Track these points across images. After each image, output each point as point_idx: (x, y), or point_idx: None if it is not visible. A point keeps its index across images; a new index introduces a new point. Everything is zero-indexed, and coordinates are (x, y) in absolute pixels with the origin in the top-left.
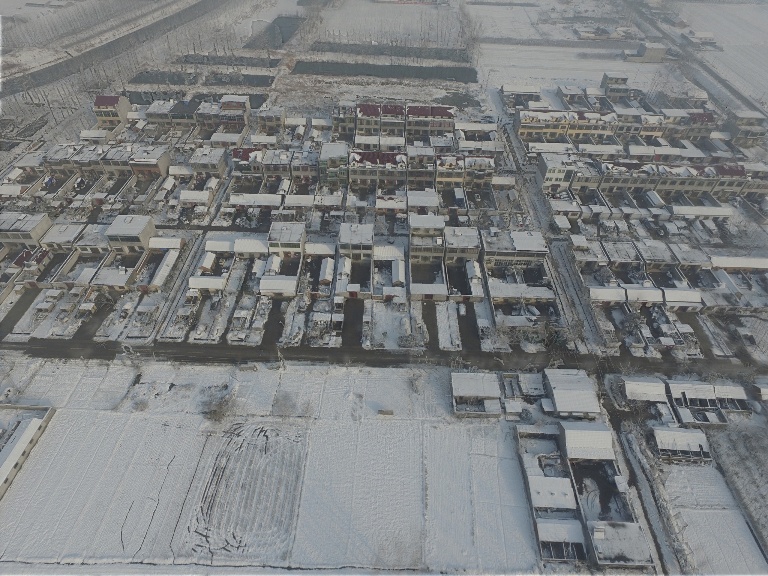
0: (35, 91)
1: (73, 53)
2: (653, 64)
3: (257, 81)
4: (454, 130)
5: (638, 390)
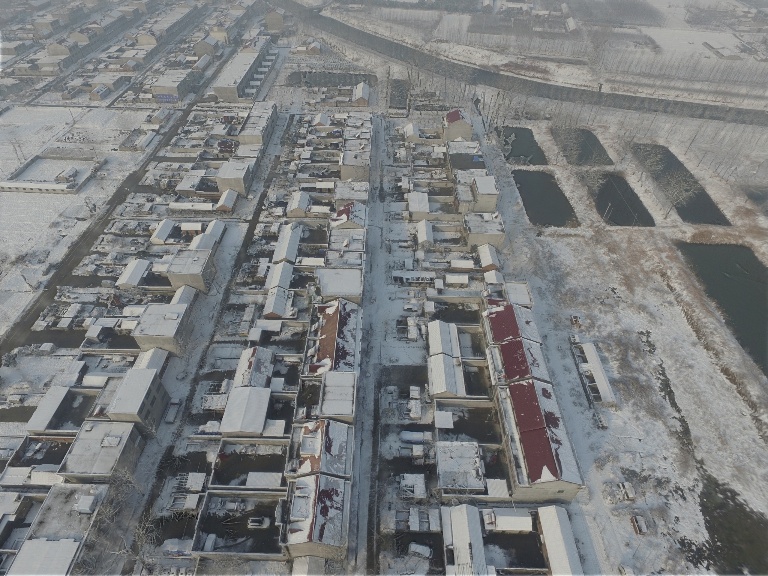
0: (470, 87)
1: (605, 88)
2: None
3: (649, 218)
4: (535, 507)
5: None
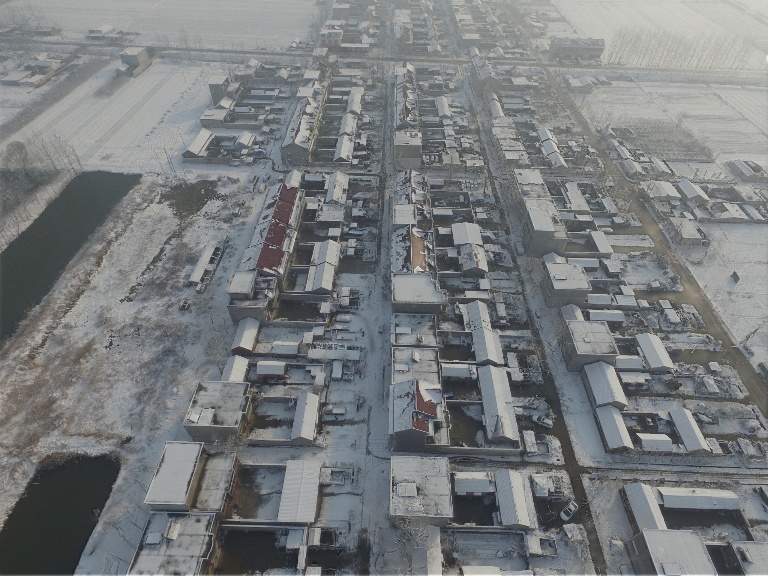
0: None
1: None
2: (152, 67)
3: None
4: None
5: (639, 169)
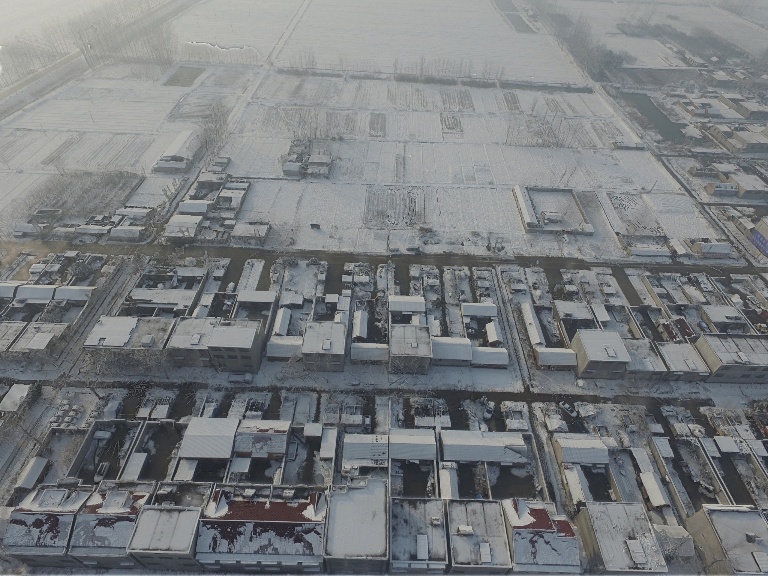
0: None
1: None
2: None
3: None
4: None
5: (134, 228)
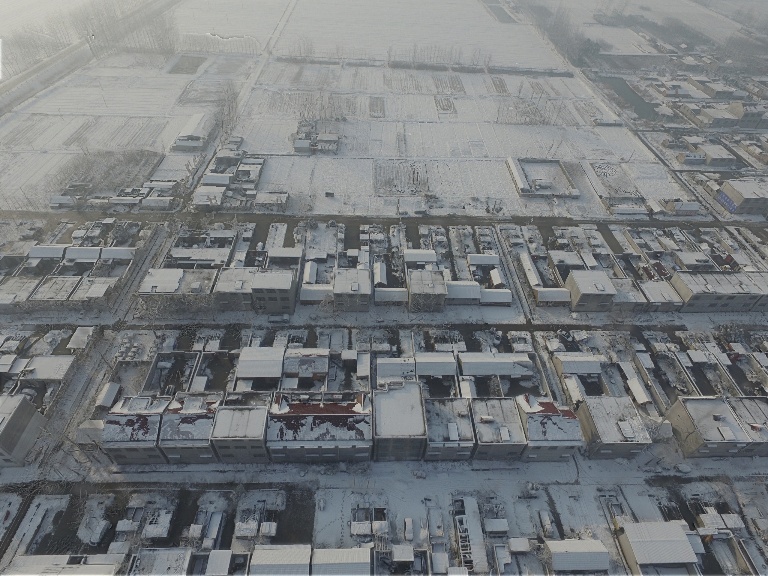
0: None
1: None
2: None
3: None
4: None
5: None
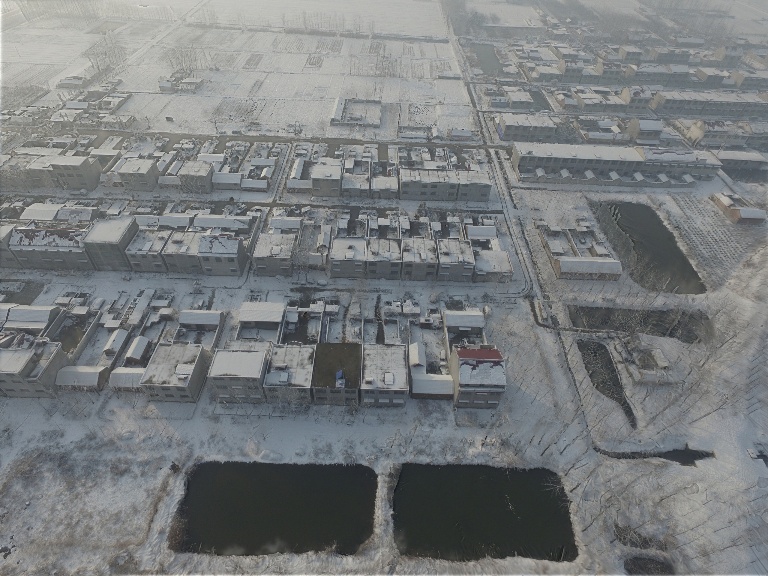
0: (666, 410)
1: None
2: None
3: None
4: None
5: None
